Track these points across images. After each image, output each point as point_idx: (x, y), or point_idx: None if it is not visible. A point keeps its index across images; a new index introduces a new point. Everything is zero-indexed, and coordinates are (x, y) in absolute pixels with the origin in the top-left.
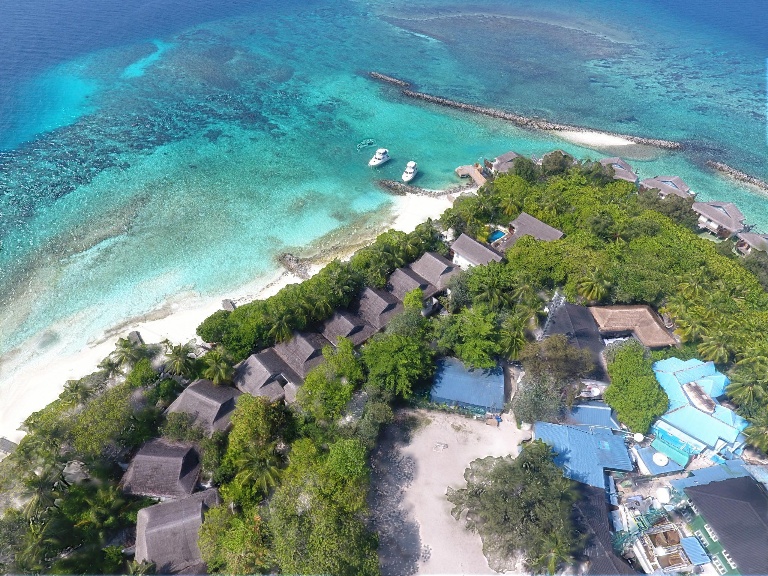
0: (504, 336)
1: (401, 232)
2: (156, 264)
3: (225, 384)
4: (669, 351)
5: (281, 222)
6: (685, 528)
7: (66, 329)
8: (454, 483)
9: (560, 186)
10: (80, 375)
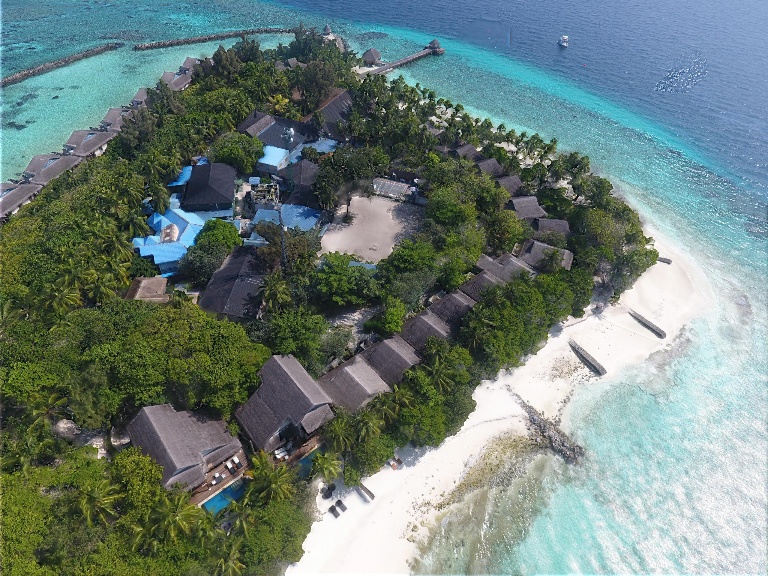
0: (317, 258)
1: (409, 418)
2: (739, 442)
3: (543, 268)
4: (149, 274)
5: (630, 565)
6: (237, 209)
7: (730, 344)
8: (369, 233)
9: (21, 571)
10: (666, 300)
